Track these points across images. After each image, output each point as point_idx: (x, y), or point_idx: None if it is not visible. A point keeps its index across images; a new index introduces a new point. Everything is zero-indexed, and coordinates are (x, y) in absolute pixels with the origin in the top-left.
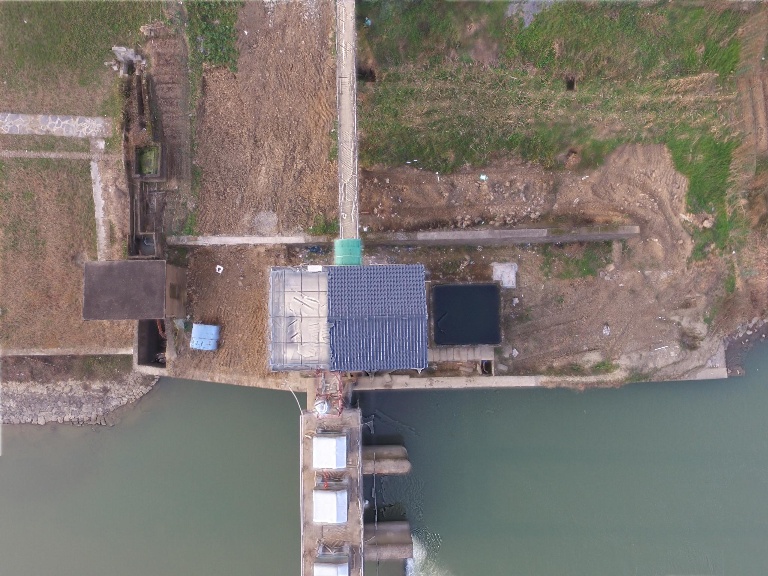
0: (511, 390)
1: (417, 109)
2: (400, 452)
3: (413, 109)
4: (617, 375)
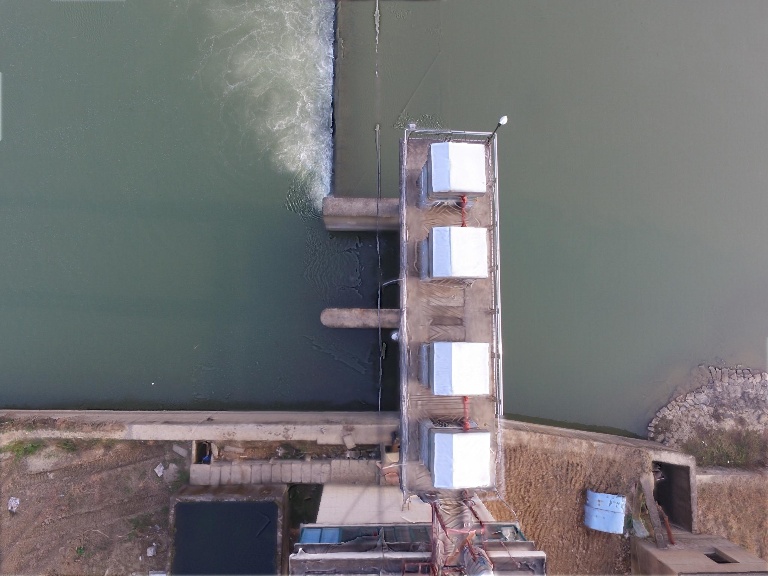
0: (176, 395)
1: None
2: None
3: None
4: (4, 438)
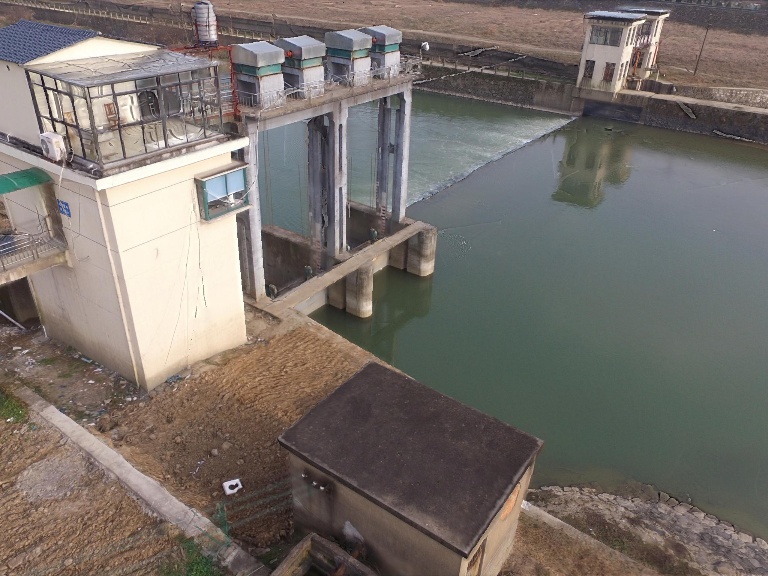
0: None
1: None
2: (266, 254)
3: None
4: None
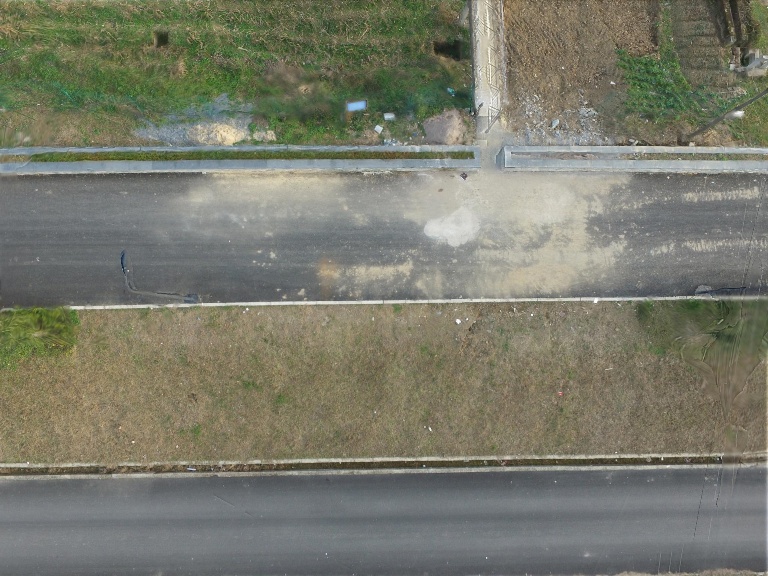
0: None
1: (377, 7)
2: None
3: (383, 7)
4: None
